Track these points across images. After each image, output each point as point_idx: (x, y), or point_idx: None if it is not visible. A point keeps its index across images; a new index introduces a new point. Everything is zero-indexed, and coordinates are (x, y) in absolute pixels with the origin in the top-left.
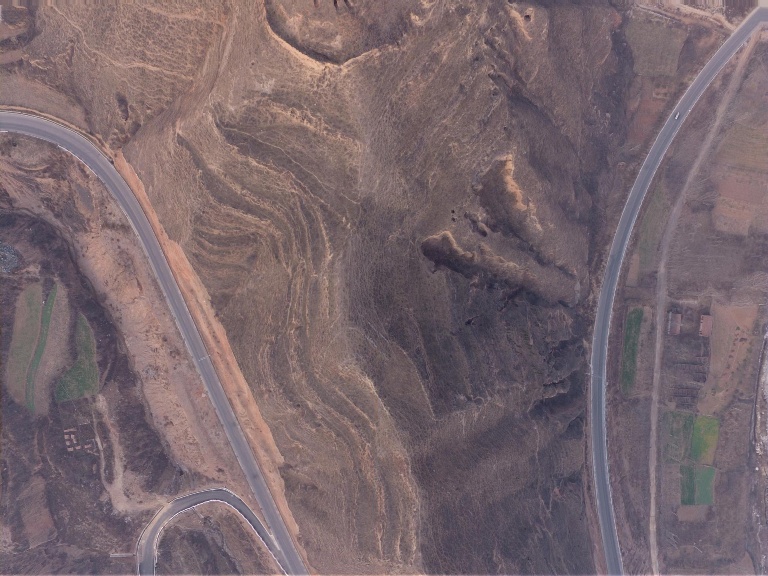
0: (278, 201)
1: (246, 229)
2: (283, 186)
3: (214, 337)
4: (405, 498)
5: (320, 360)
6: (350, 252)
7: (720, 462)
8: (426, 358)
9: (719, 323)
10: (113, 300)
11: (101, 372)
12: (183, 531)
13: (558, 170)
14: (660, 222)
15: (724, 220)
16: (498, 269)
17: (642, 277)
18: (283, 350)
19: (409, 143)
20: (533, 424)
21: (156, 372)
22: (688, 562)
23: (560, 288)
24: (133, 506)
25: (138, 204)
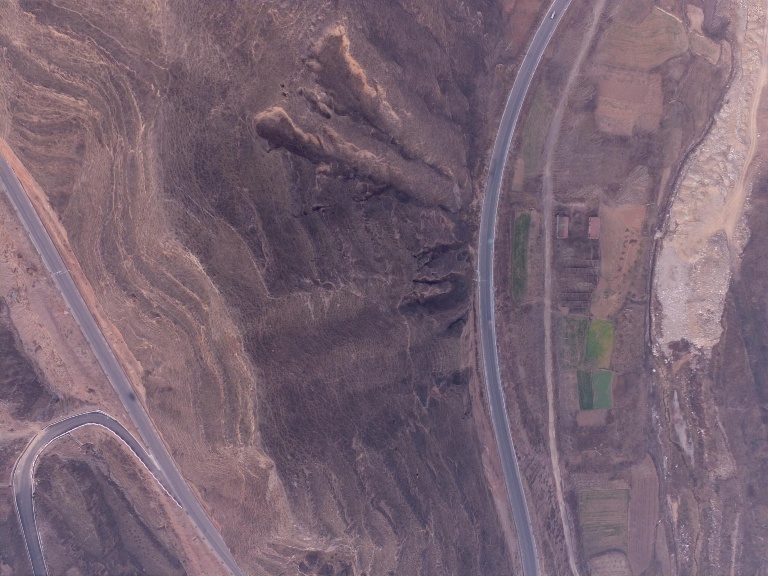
0: (88, 75)
1: (66, 113)
2: (91, 58)
3: (65, 246)
4: (242, 379)
5: (143, 240)
6: (162, 121)
7: (616, 365)
8: (265, 240)
9: (608, 225)
10: None
11: None
12: (63, 460)
13: (414, 58)
14: (543, 125)
15: (608, 121)
16: (356, 161)
17: (528, 182)
18: (112, 237)
19: (218, 5)
20: (403, 319)
21: (18, 294)
22: (590, 467)
23: (433, 187)
24: (4, 435)
25: None
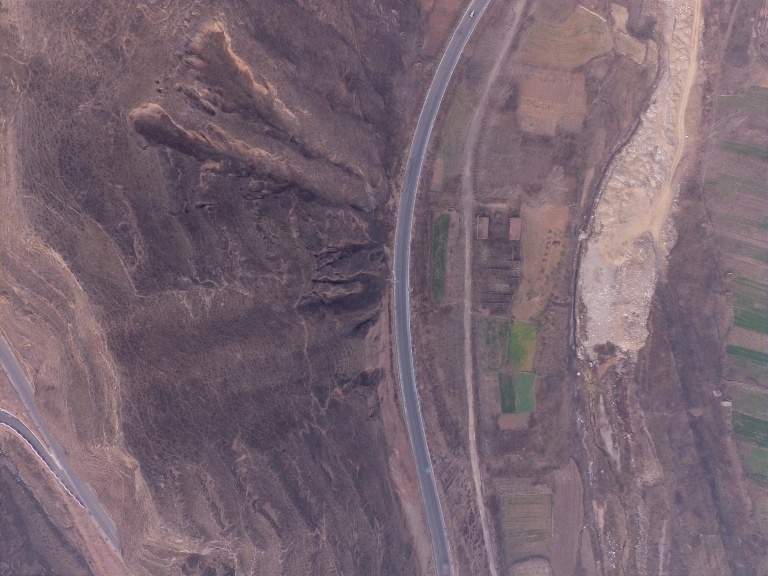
0: None
1: None
2: None
3: None
4: (108, 378)
5: (7, 236)
6: (21, 116)
7: (539, 368)
8: (139, 237)
9: (530, 226)
10: None
11: None
12: None
13: (312, 55)
14: (463, 125)
15: (530, 121)
16: (252, 159)
17: (447, 181)
18: None
19: None
20: (300, 319)
21: None
22: (513, 471)
23: (341, 186)
24: None
25: None
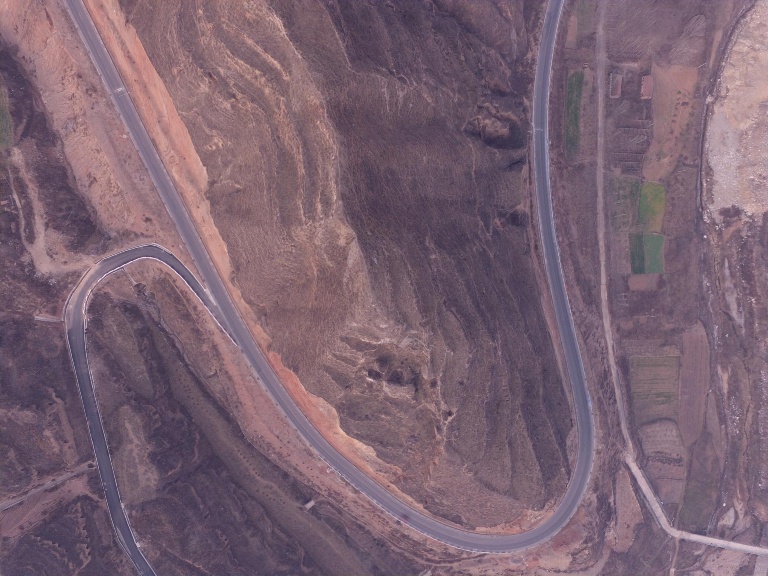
0: None
1: None
2: None
3: (129, 58)
4: (323, 150)
5: (225, 4)
6: None
7: (668, 228)
8: (343, 22)
9: (660, 87)
10: (26, 51)
11: (15, 123)
12: (115, 300)
13: None
14: None
15: None
16: None
17: (581, 39)
18: (189, 12)
19: None
20: (468, 141)
21: (74, 121)
22: (641, 333)
23: (494, 25)
24: (57, 267)
25: None
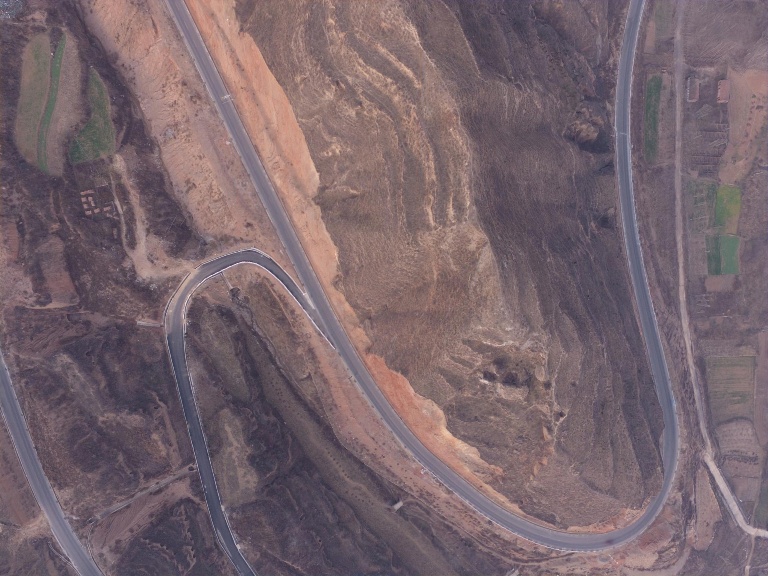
0: None
1: None
2: None
3: (238, 65)
4: (455, 156)
5: (360, 14)
6: None
7: (744, 230)
8: None
9: (736, 91)
10: (125, 59)
11: (117, 130)
12: (211, 305)
13: None
14: None
15: None
16: None
17: (659, 44)
18: (319, 21)
19: None
20: (568, 146)
21: (175, 128)
22: (718, 333)
23: (584, 31)
24: (158, 272)
25: None
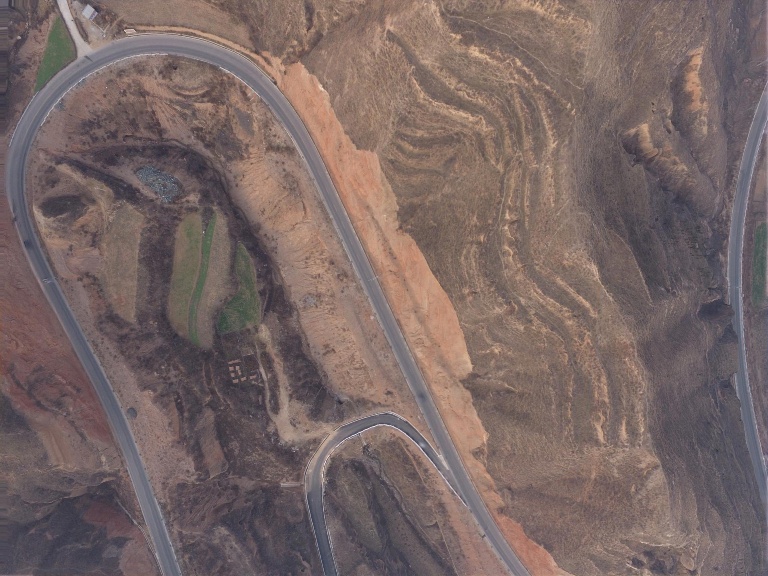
0: (495, 93)
1: (451, 129)
2: (501, 77)
3: (390, 254)
4: (629, 383)
5: (542, 250)
6: (575, 138)
7: None
8: None
9: None
10: (268, 230)
11: (263, 301)
12: (345, 460)
13: None
14: None
15: None
16: (666, 174)
17: None
18: (495, 247)
19: (627, 28)
20: (703, 325)
21: (318, 299)
22: None
23: (708, 198)
24: (300, 435)
25: (303, 125)
